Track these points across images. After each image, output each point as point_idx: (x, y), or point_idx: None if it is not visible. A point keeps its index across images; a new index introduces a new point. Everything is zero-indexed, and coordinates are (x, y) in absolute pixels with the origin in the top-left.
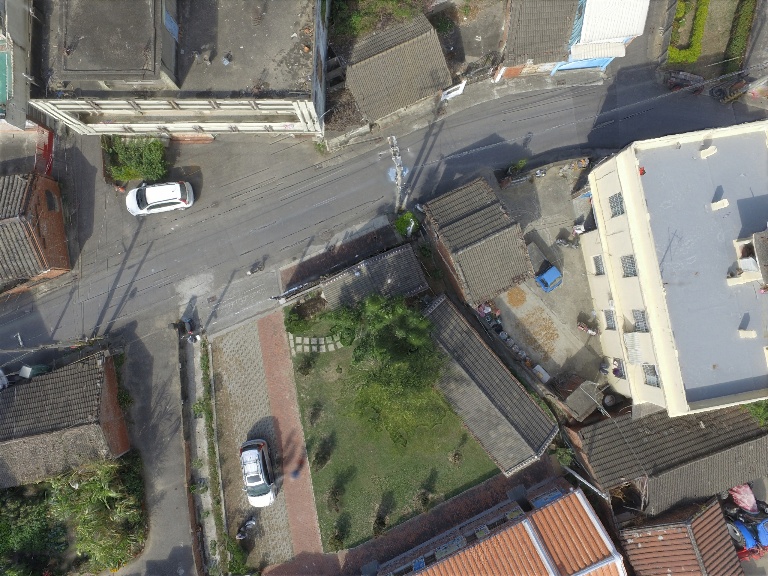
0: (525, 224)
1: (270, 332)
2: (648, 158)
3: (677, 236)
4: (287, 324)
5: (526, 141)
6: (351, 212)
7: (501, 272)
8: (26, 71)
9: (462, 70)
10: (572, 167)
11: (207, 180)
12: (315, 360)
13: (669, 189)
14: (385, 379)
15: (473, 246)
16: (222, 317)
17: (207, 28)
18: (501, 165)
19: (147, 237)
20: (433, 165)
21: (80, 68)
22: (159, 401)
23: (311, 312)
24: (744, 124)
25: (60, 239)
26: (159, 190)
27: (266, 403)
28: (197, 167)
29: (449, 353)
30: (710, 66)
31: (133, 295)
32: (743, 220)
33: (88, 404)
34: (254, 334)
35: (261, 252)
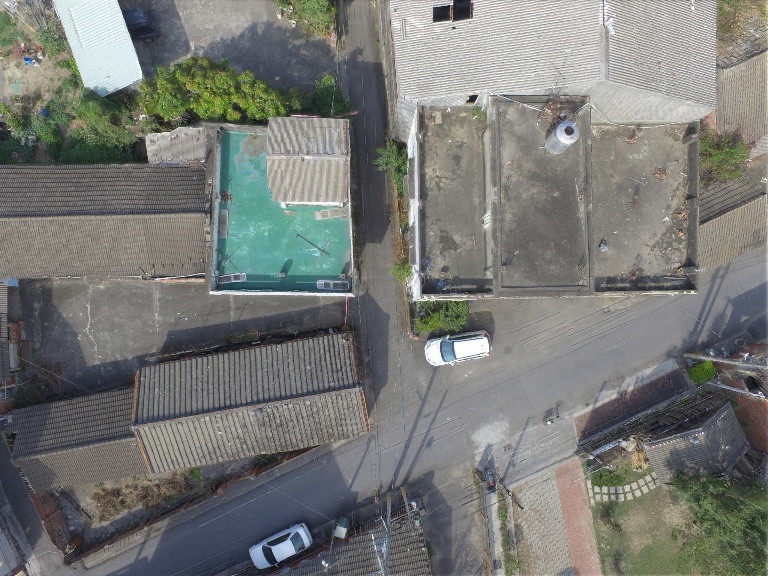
0: None
1: (568, 481)
2: None
3: None
4: (597, 478)
5: None
6: (641, 356)
7: None
8: None
9: None
10: None
11: (499, 326)
12: (614, 509)
13: None
14: (728, 549)
15: None
16: (520, 466)
17: None
18: None
19: (441, 385)
20: (720, 308)
21: (516, 284)
22: (459, 552)
23: (608, 460)
24: None
25: None
26: (468, 344)
27: (567, 553)
28: (489, 312)
29: None
30: None
31: (430, 444)
32: None
33: (418, 571)
34: (552, 483)
35: (554, 398)
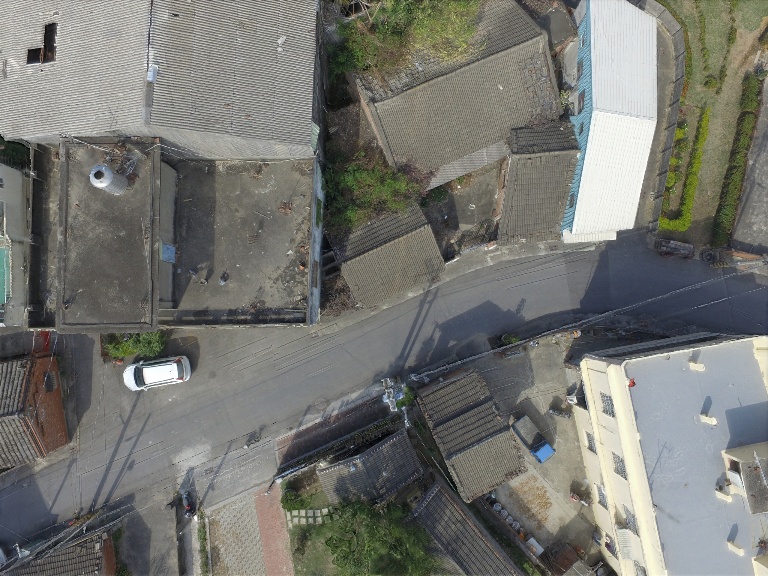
0: (518, 392)
1: (267, 504)
2: (638, 369)
3: (667, 448)
4: (283, 503)
5: (519, 307)
6: (347, 381)
7: (494, 470)
8: (24, 260)
9: (456, 238)
10: (565, 335)
11: (204, 351)
12: (311, 532)
13: (659, 401)
14: None
15: (467, 451)
16: (219, 489)
17: (204, 247)
18: (495, 332)
19: (144, 409)
20: (428, 333)
21: (78, 321)
22: (157, 574)
23: (307, 483)
24: (732, 341)
25: (58, 416)
26: (156, 370)
27: (263, 575)
28: (194, 338)
29: (443, 549)
30: (700, 231)
31: (131, 468)
32: (731, 431)
33: None
34: (251, 506)
35: (258, 422)
